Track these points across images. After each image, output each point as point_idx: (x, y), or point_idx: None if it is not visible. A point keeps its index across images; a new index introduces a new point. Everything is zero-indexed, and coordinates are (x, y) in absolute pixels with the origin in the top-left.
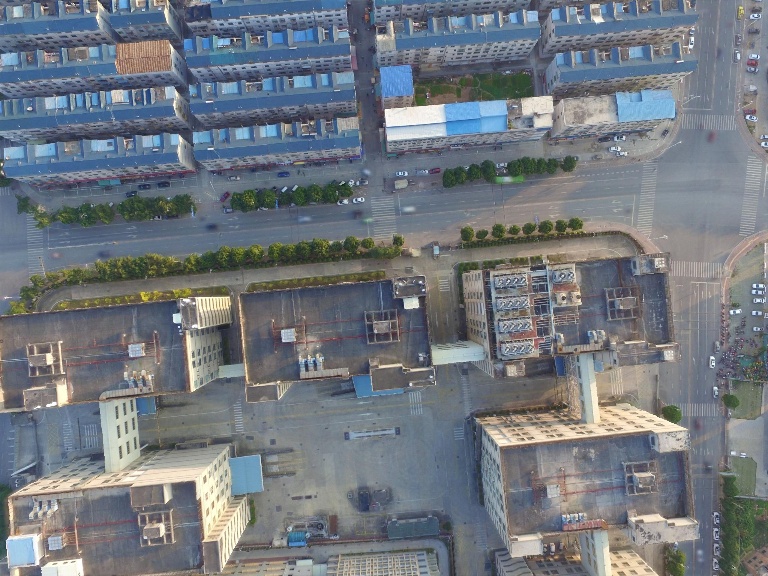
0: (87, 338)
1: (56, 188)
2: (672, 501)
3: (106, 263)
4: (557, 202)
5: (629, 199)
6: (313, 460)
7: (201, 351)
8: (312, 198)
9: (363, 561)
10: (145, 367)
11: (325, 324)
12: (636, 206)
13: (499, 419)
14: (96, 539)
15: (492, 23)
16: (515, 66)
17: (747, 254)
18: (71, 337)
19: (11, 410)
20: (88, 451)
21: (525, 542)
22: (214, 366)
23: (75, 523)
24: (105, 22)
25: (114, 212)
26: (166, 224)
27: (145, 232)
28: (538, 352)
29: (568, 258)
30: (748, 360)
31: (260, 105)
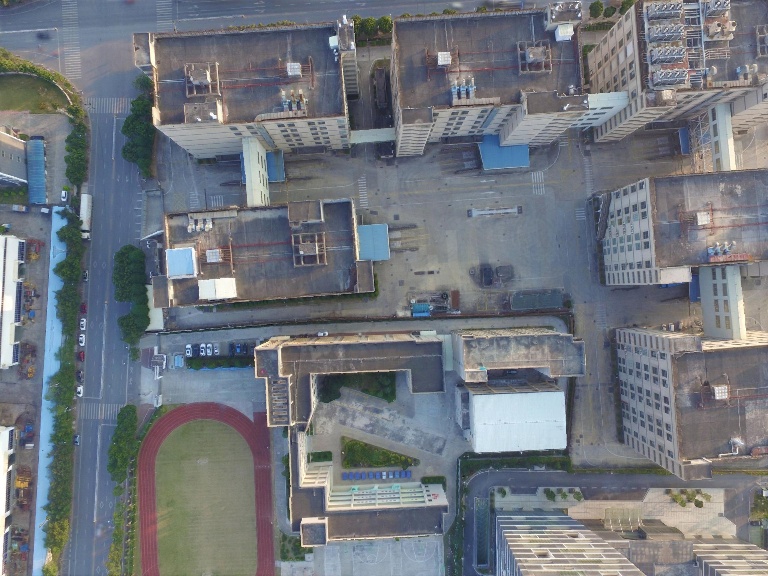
0: (242, 62)
1: None
2: None
3: (239, 28)
4: None
5: None
6: (436, 236)
7: (345, 95)
8: None
9: None
10: None
11: (477, 54)
12: None
13: None
14: (249, 259)
15: None
16: None
17: None
18: (227, 60)
19: None
20: None
21: (674, 269)
22: None
23: (230, 241)
24: None
25: None
26: None
27: (273, 7)
28: (690, 83)
29: None
30: None
31: None
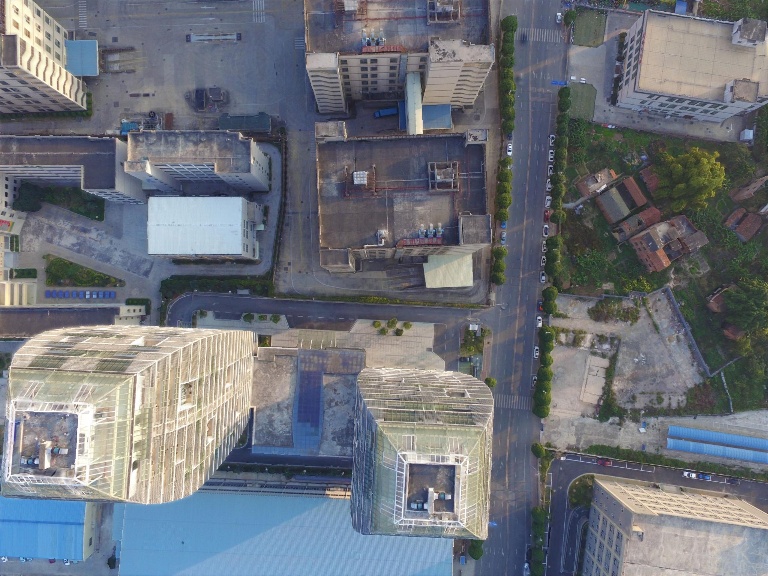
0: None
1: None
2: (475, 36)
3: None
4: None
5: None
6: (153, 60)
7: None
8: None
9: None
10: None
11: None
12: None
13: None
14: None
15: None
16: None
17: None
18: None
19: None
20: None
21: (320, 54)
22: None
23: None
24: None
25: None
26: None
27: None
28: None
29: None
30: None
31: None
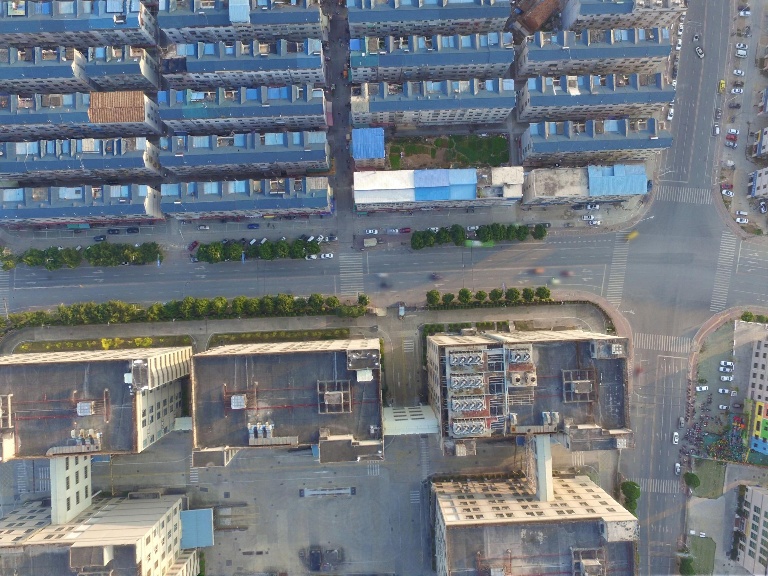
0: (38, 392)
1: (25, 228)
2: None
3: (69, 308)
4: (527, 268)
5: (600, 268)
6: (266, 515)
7: (154, 407)
8: (278, 254)
9: None
10: (94, 425)
11: (277, 391)
12: (606, 276)
13: (455, 486)
14: None
15: (467, 90)
16: (492, 129)
17: (717, 330)
18: (22, 390)
19: None
20: (41, 494)
21: None
22: (169, 419)
23: None
24: (81, 69)
25: (81, 256)
26: (133, 270)
27: (111, 277)
28: (490, 432)
29: (535, 325)
30: (712, 438)
31: (230, 160)
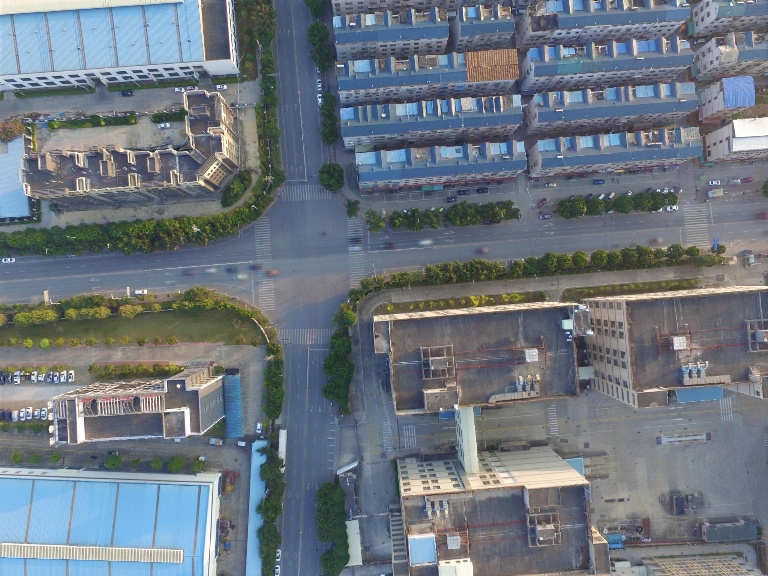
0: (476, 342)
1: (377, 192)
2: None
3: (437, 267)
4: None
5: None
6: (626, 464)
7: None
8: (643, 206)
9: (683, 564)
10: (531, 371)
11: (706, 332)
12: None
13: None
14: (484, 539)
15: None
16: None
17: None
18: (460, 341)
19: (409, 412)
20: (407, 451)
21: None
22: None
23: (466, 523)
24: None
25: (439, 217)
26: (483, 229)
27: (463, 237)
28: None
29: None
30: None
31: (605, 114)
